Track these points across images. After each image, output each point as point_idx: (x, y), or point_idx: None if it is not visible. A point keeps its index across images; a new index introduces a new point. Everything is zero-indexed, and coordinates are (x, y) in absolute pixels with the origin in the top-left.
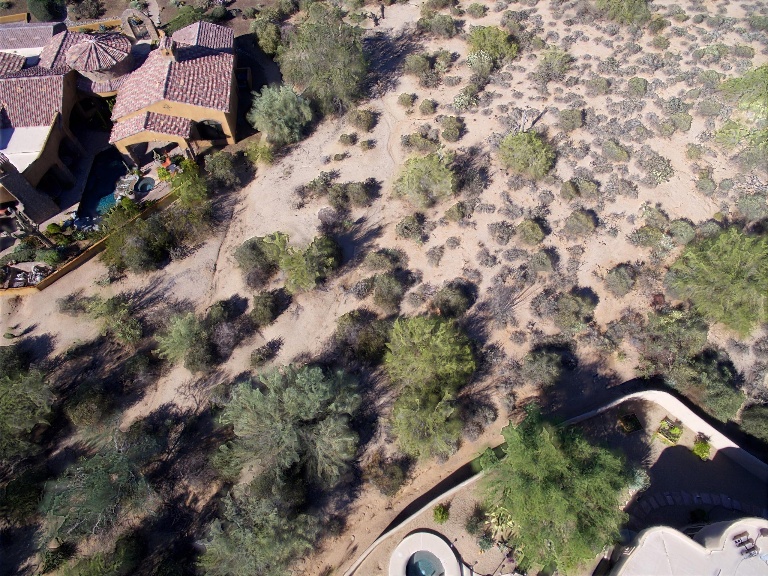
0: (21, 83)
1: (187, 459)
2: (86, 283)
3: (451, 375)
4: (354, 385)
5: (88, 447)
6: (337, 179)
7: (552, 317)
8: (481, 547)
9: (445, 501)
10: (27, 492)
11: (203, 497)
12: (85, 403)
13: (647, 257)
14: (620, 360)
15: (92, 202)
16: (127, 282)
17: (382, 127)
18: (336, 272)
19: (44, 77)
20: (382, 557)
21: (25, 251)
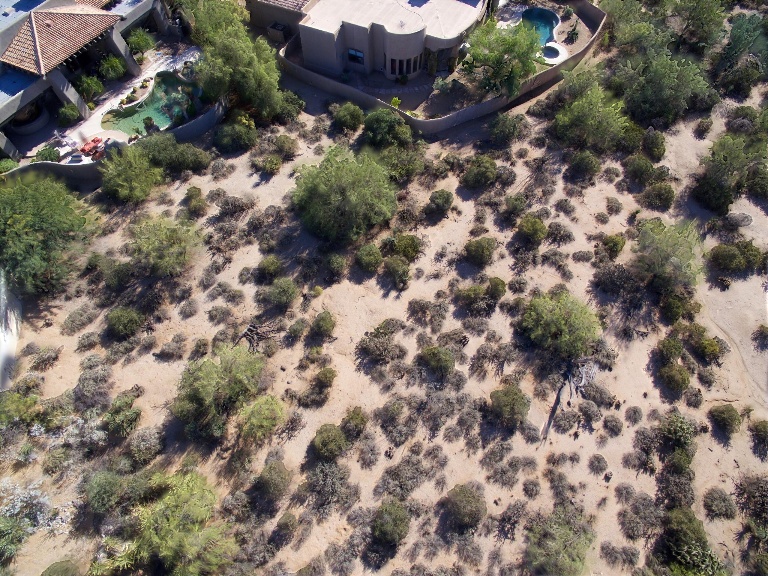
0: None
1: None
2: None
3: None
4: None
5: (766, 83)
6: (763, 282)
7: None
8: None
9: None
10: None
11: None
12: None
13: None
14: None
15: None
16: None
17: (766, 379)
18: None
19: None
20: None
21: None
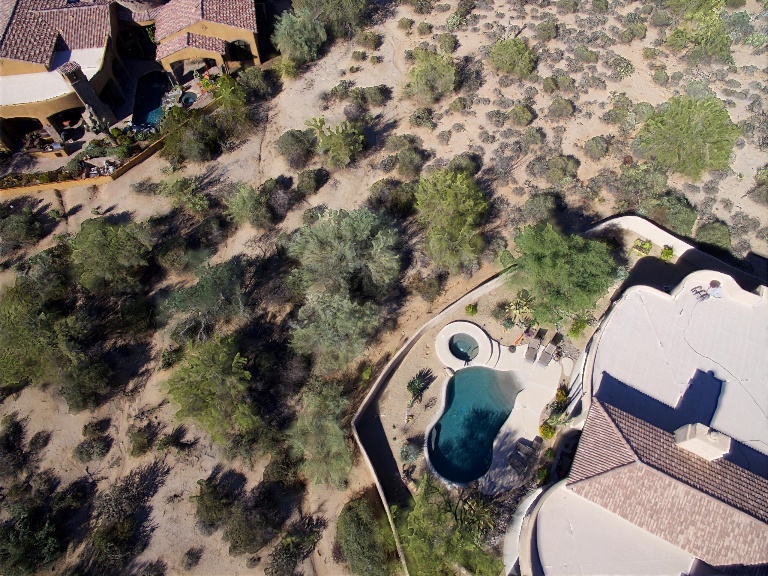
0: (72, 12)
1: (262, 290)
2: (152, 173)
3: (470, 211)
4: (393, 222)
5: (178, 288)
6: (354, 87)
7: (544, 176)
8: (504, 327)
9: (473, 302)
10: (139, 313)
11: (280, 314)
12: (174, 250)
13: (617, 132)
14: (600, 204)
15: (142, 115)
16: (187, 171)
17: (387, 46)
18: (363, 155)
19: (92, 7)
20: (429, 340)
21: (96, 149)
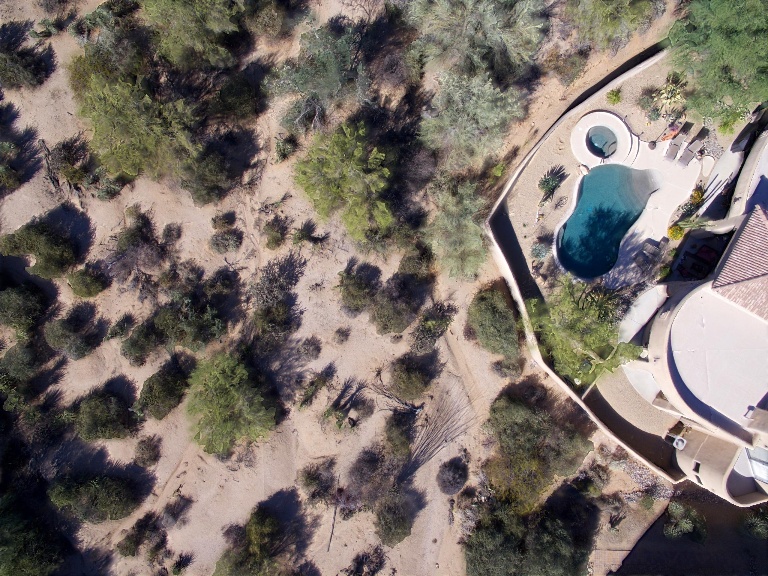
0: None
1: (372, 66)
2: None
3: None
4: None
5: (272, 62)
6: None
7: None
8: (649, 120)
9: (615, 88)
10: (241, 95)
11: (395, 98)
12: (264, 10)
13: None
14: None
15: None
16: None
17: None
18: None
19: None
20: (563, 133)
21: None
